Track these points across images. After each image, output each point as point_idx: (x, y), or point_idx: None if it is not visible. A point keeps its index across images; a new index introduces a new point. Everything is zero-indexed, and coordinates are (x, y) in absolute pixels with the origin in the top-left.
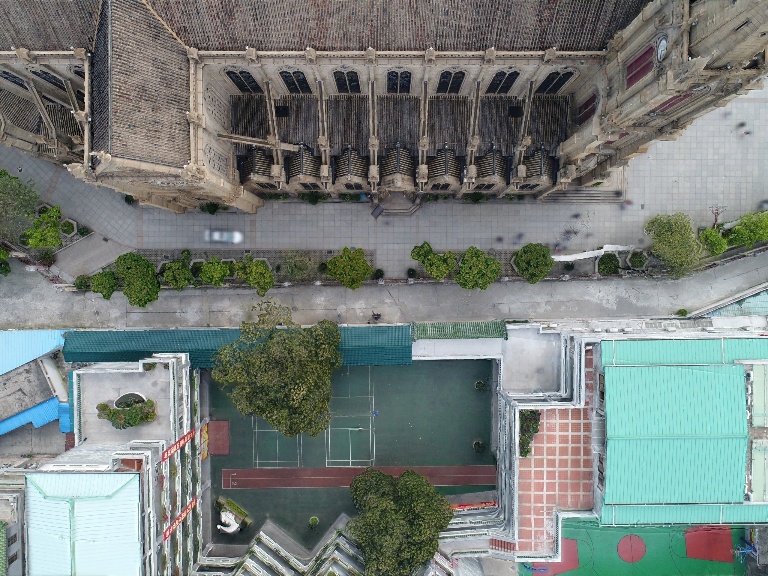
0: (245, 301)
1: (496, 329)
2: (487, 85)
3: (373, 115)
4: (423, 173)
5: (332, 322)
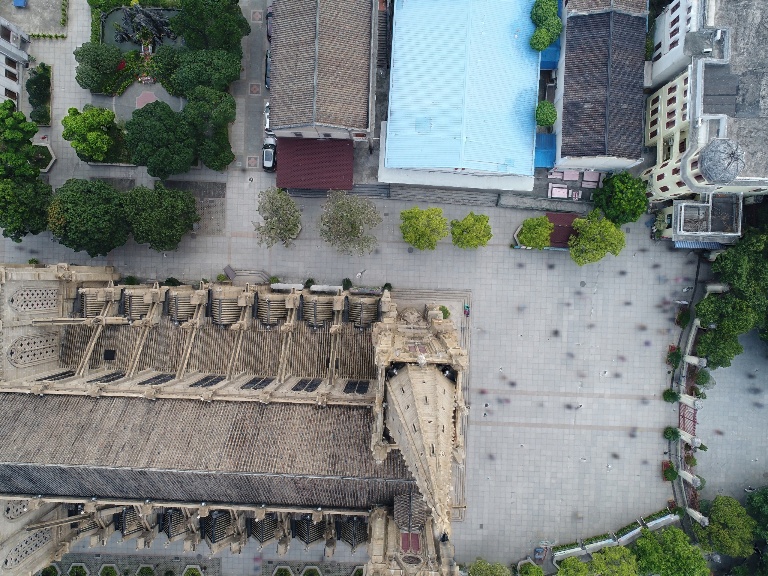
0: None
1: None
2: None
3: None
4: None
5: None
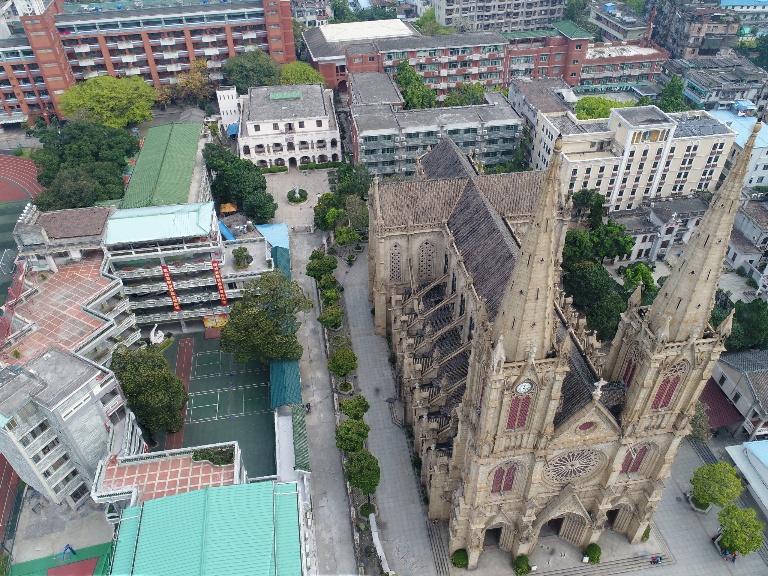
0: (314, 336)
1: (303, 463)
2: None
3: None
4: None
5: None
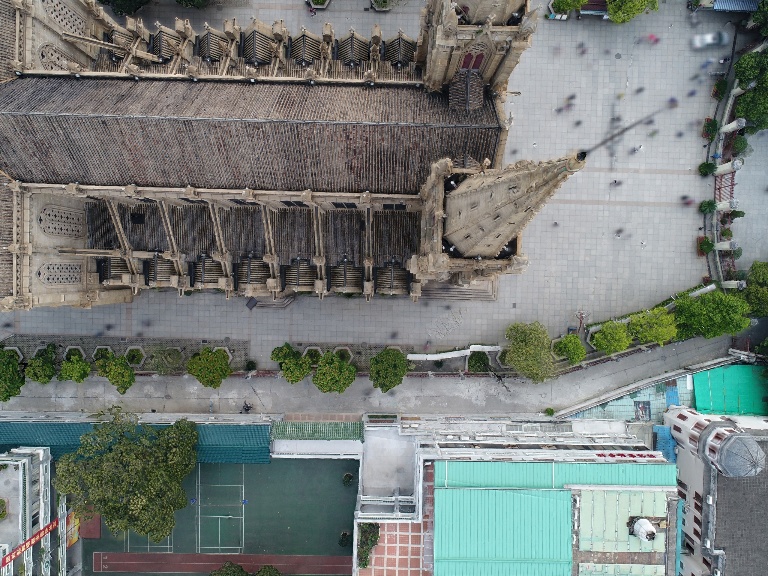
0: None
1: (354, 431)
2: (331, 205)
3: (218, 231)
4: (269, 288)
5: (190, 422)
